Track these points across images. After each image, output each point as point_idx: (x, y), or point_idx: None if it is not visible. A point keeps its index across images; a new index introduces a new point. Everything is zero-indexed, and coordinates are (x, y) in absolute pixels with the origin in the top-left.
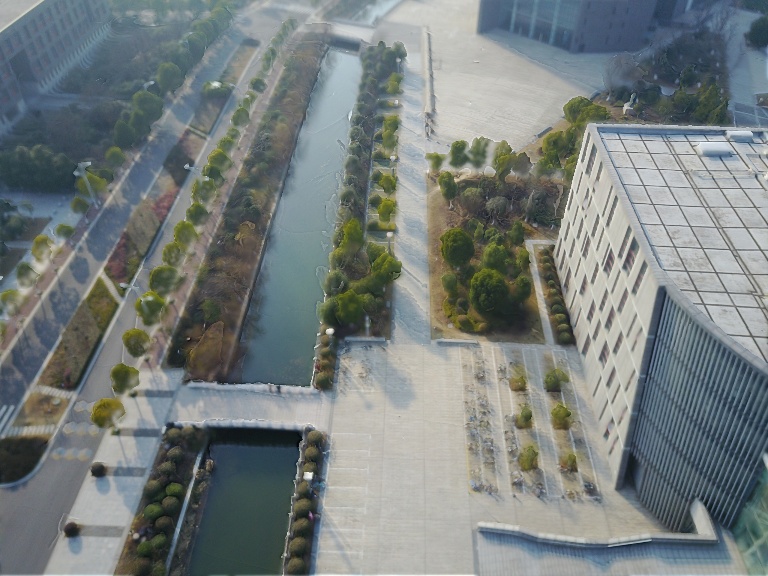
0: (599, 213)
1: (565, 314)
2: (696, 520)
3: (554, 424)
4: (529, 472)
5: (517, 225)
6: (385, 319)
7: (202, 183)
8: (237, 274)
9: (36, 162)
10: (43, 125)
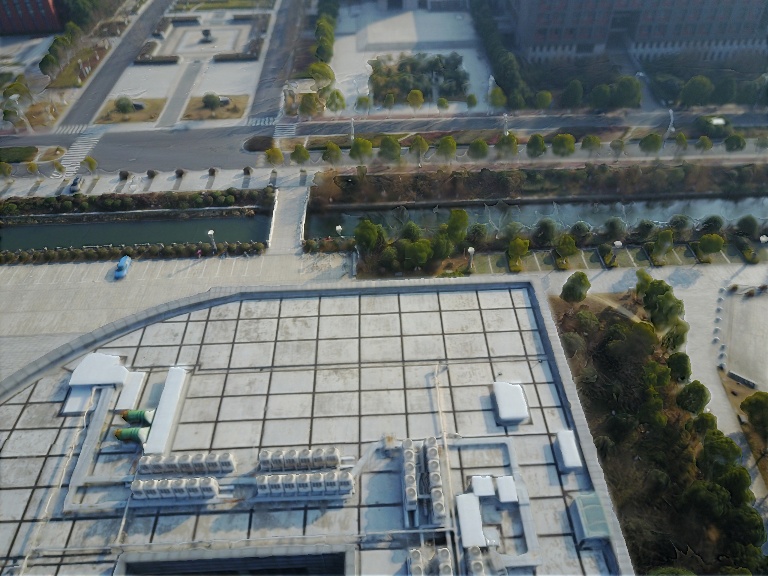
0: None
1: None
2: None
3: None
4: None
5: None
6: (377, 272)
7: (503, 134)
8: (424, 189)
9: (503, 67)
10: (585, 66)
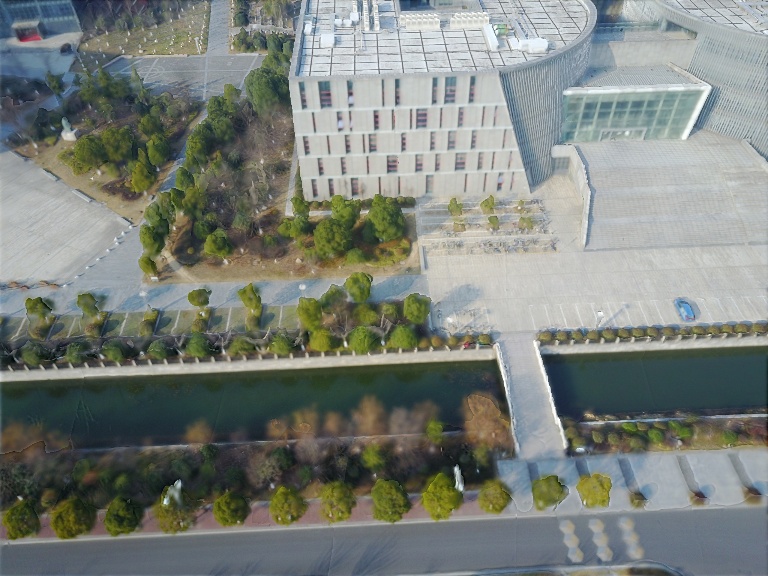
0: (379, 107)
1: None
2: (559, 154)
3: (491, 213)
4: None
5: (298, 199)
6: None
7: (182, 495)
8: (339, 447)
9: None
10: None
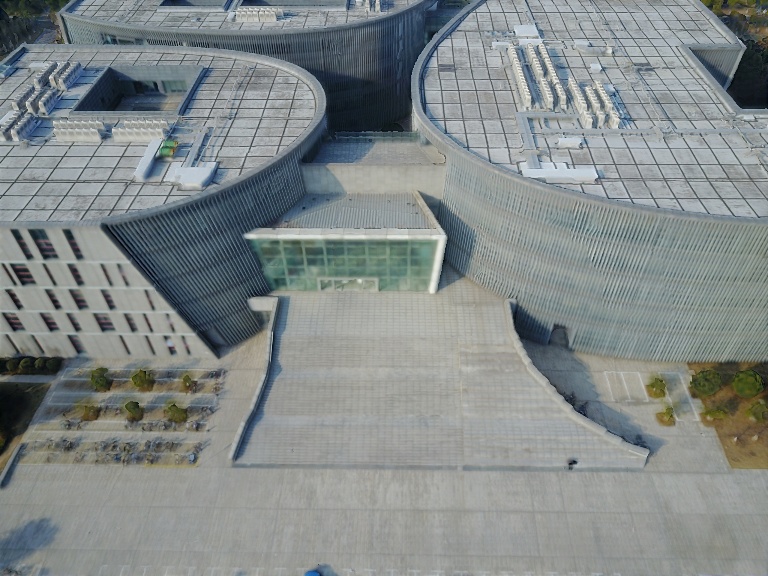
0: None
1: (23, 358)
2: (260, 308)
3: (147, 390)
4: (188, 416)
5: None
6: None
7: None
8: None
9: None
10: None
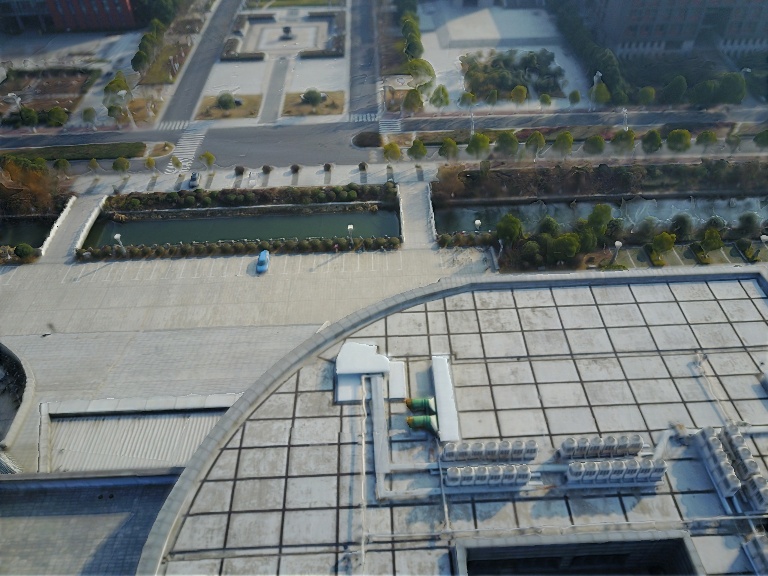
0: None
1: None
2: None
3: None
4: None
5: None
6: (521, 266)
7: (622, 130)
8: (545, 185)
9: (602, 63)
10: (676, 62)
